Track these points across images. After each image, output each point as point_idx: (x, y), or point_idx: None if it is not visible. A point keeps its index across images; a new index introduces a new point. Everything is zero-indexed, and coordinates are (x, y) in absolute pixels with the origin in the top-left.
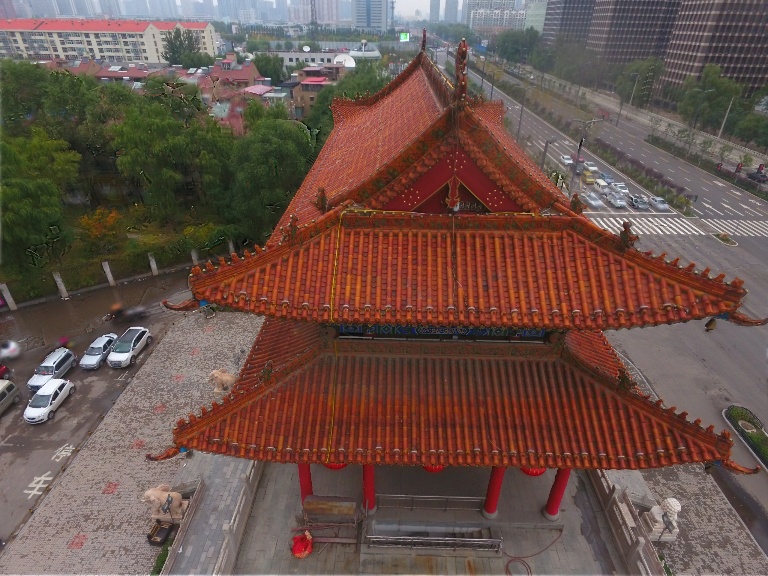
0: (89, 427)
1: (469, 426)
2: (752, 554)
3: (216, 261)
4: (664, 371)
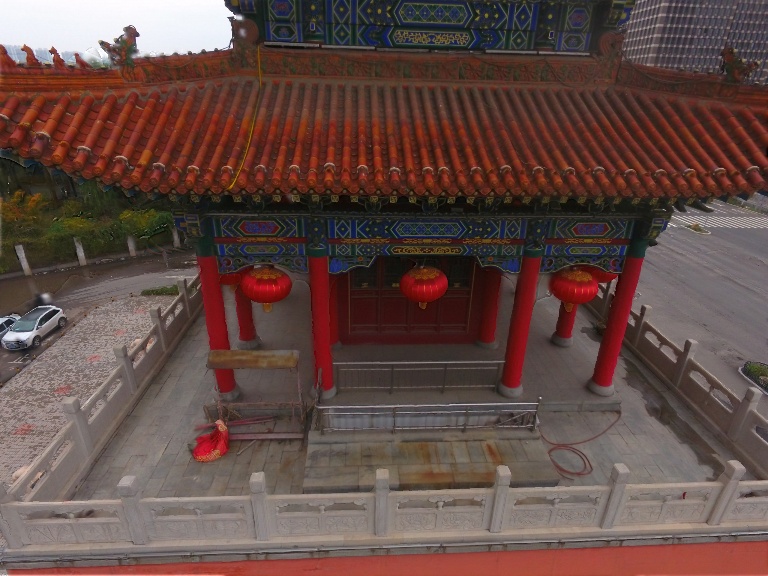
0: None
1: (487, 151)
2: None
3: (157, 253)
4: None
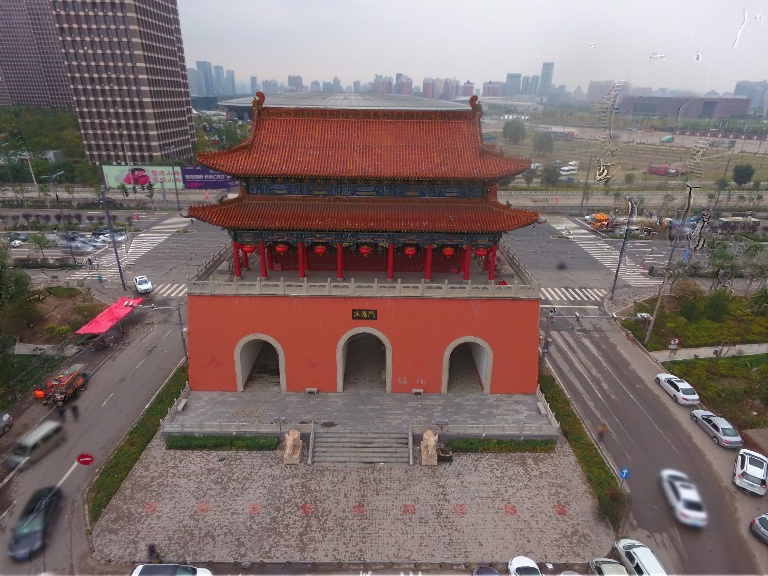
0: (329, 573)
1: None
2: None
3: None
4: None
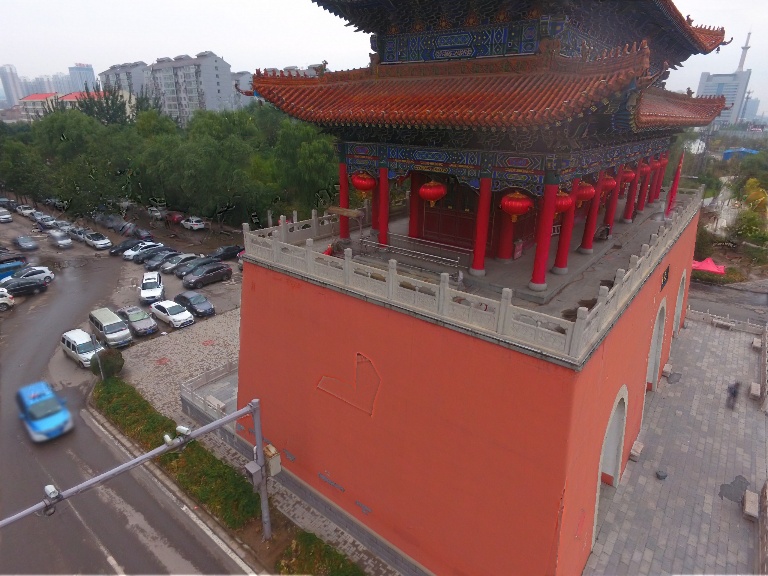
0: None
1: None
2: None
3: None
4: None
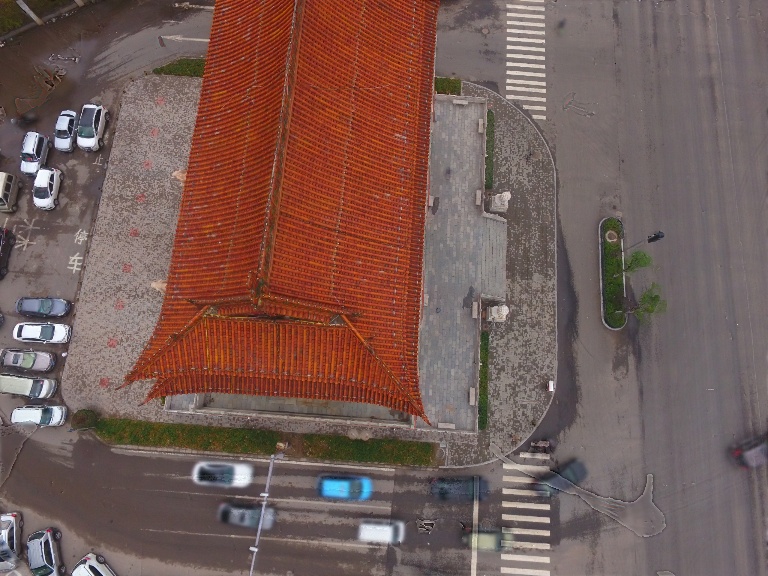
0: (91, 214)
1: None
2: (549, 332)
3: None
4: (578, 173)
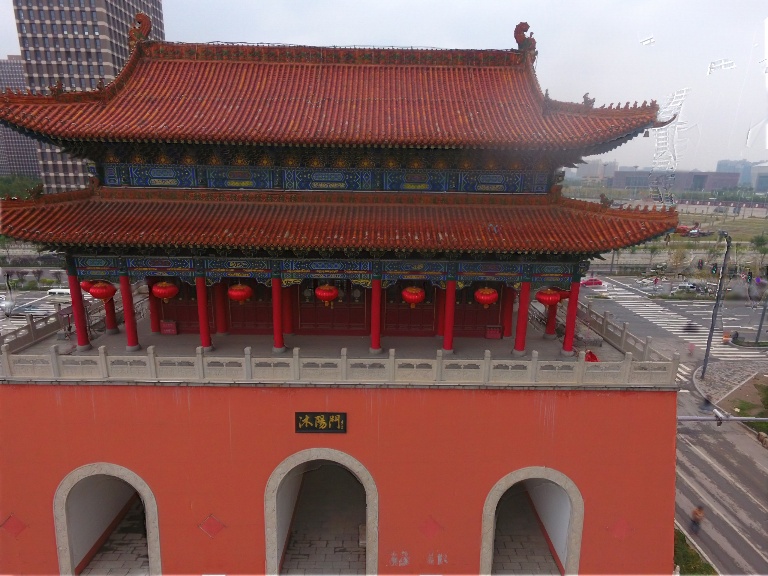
0: None
1: None
2: None
3: None
4: None
